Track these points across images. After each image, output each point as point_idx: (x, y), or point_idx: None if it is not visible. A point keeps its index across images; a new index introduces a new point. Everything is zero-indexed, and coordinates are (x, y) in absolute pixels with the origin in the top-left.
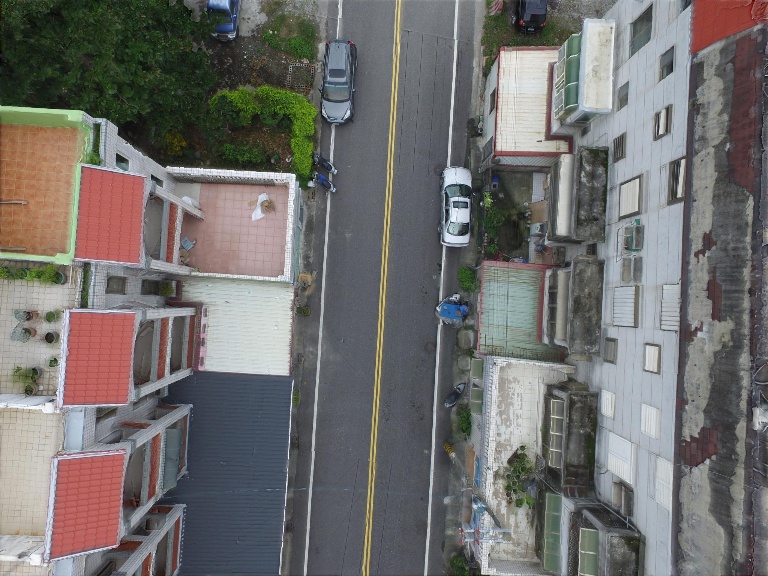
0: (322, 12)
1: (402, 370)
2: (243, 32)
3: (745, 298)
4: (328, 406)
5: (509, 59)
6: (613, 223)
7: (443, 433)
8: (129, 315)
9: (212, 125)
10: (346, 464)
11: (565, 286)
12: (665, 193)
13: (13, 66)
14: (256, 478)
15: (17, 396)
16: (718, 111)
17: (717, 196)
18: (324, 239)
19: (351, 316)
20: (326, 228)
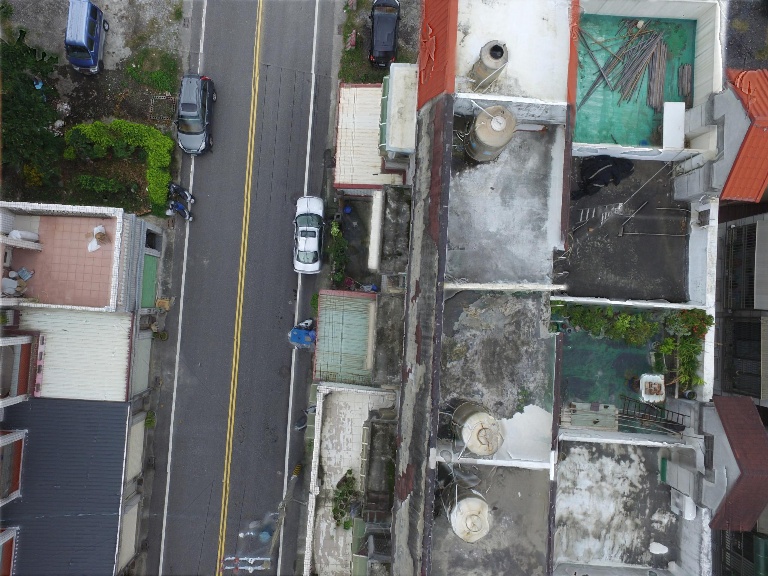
0: (185, 46)
1: (257, 393)
2: (108, 66)
3: (431, 344)
4: (184, 428)
5: (348, 95)
6: None
7: (296, 455)
8: None
9: (46, 161)
10: (201, 485)
11: None
12: None
13: None
14: (90, 501)
15: None
16: (427, 167)
17: (423, 246)
18: (182, 266)
19: (208, 341)
20: (184, 255)
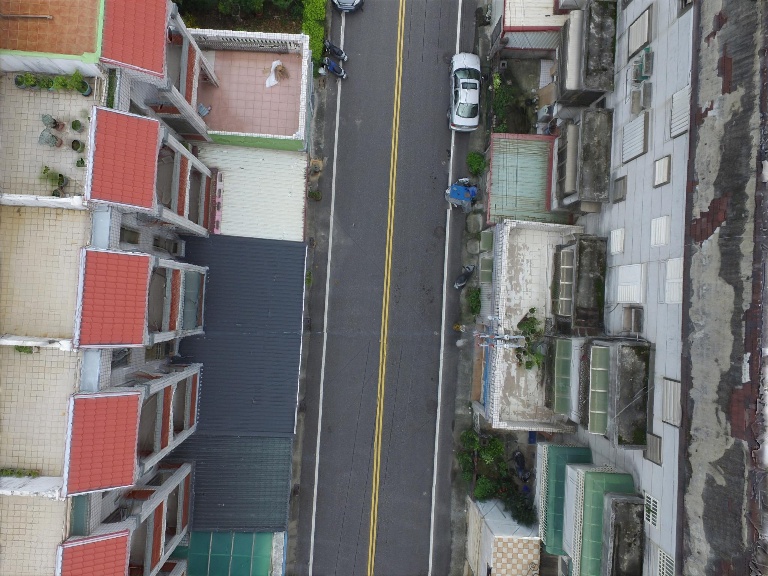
0: None
1: (412, 254)
2: None
3: (755, 61)
4: (339, 289)
5: None
6: (622, 68)
7: (453, 315)
8: (153, 122)
9: None
10: (357, 345)
11: (574, 139)
12: (674, 10)
13: None
14: (271, 340)
15: None
16: None
17: None
18: (335, 125)
19: (362, 201)
20: (337, 114)
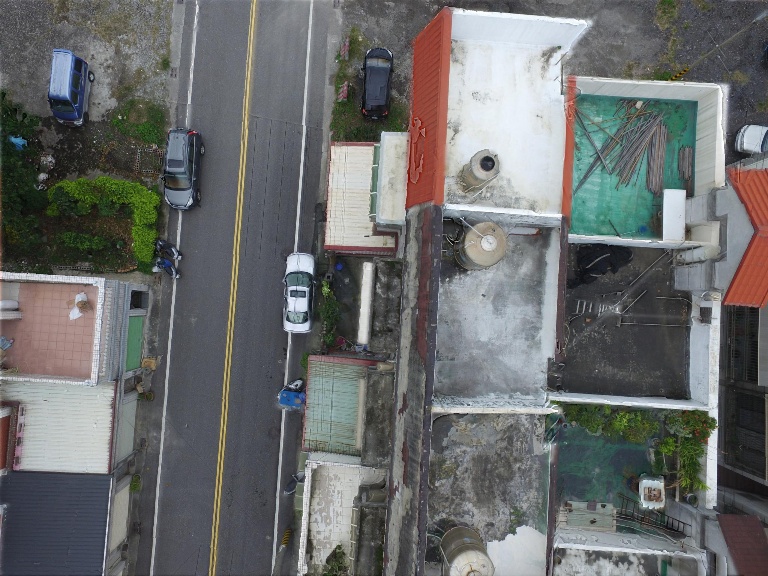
0: (173, 97)
1: (245, 455)
2: (93, 117)
3: (418, 470)
4: (170, 492)
5: (339, 154)
6: None
7: (286, 519)
8: None
9: (25, 228)
10: (188, 550)
11: None
12: None
13: None
14: None
15: None
16: (414, 274)
17: (410, 359)
18: (169, 324)
19: (195, 401)
20: (171, 313)
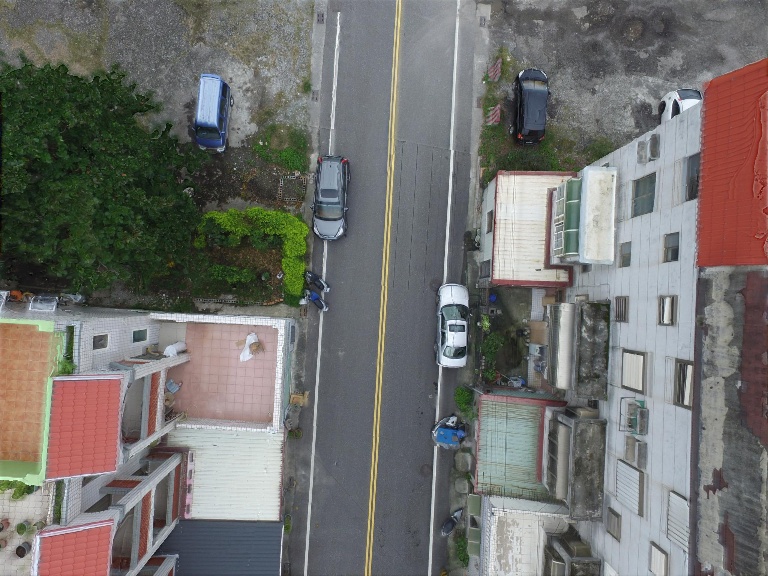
0: (314, 122)
1: (397, 494)
2: (233, 143)
3: (759, 560)
4: (321, 532)
5: (507, 184)
6: (616, 386)
7: (440, 559)
8: (104, 528)
9: (198, 267)
10: None
11: (566, 442)
12: (671, 388)
13: None
14: None
15: None
16: (728, 341)
17: (728, 434)
18: (316, 358)
19: (344, 438)
20: (318, 347)
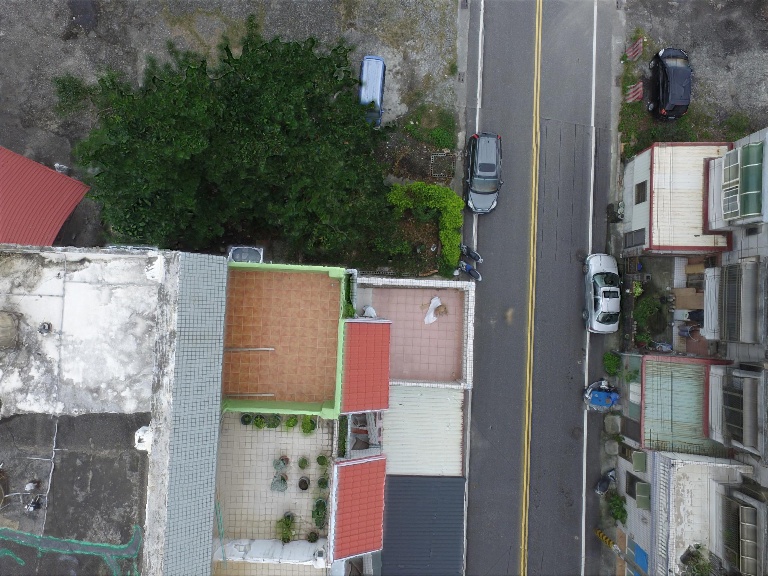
0: (461, 102)
1: (551, 456)
2: (384, 123)
3: None
4: (478, 493)
5: (664, 155)
6: None
7: (593, 519)
8: (381, 461)
9: (389, 234)
10: (498, 552)
11: (751, 393)
12: None
13: (226, 197)
14: None
15: (272, 543)
16: None
17: None
18: None
19: (498, 403)
20: None
